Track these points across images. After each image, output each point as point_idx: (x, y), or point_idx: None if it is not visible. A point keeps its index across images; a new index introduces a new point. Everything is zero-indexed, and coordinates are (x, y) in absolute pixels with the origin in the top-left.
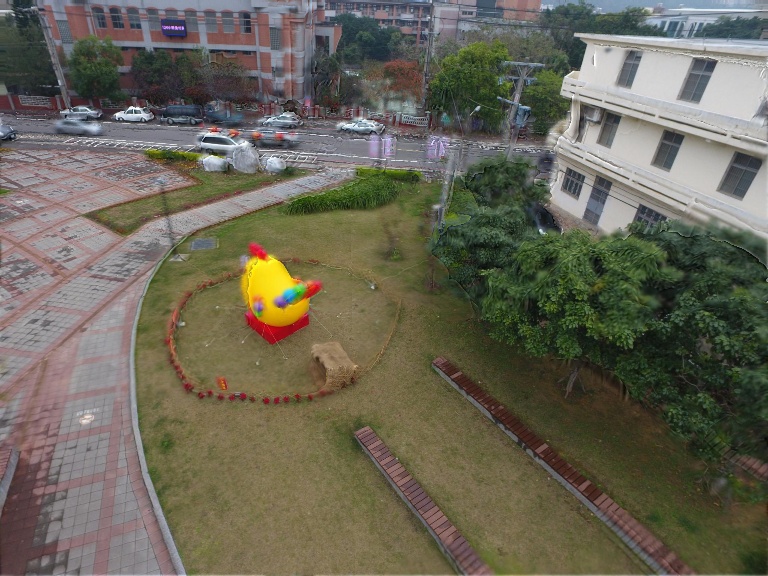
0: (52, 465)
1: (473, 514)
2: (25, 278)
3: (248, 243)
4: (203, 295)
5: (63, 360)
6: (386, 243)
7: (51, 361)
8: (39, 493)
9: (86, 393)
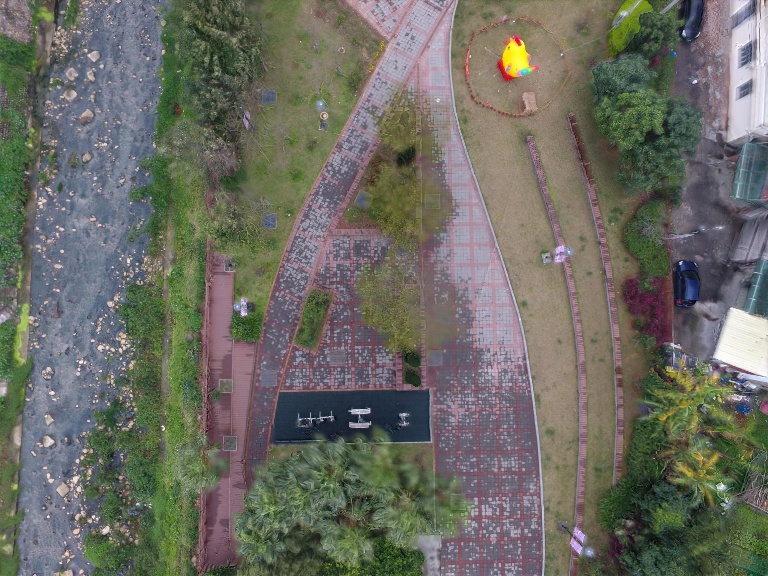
0: (431, 117)
1: (553, 176)
2: None
3: None
4: (479, 36)
5: (424, 65)
6: (584, 13)
7: (420, 64)
8: (430, 126)
9: (436, 87)
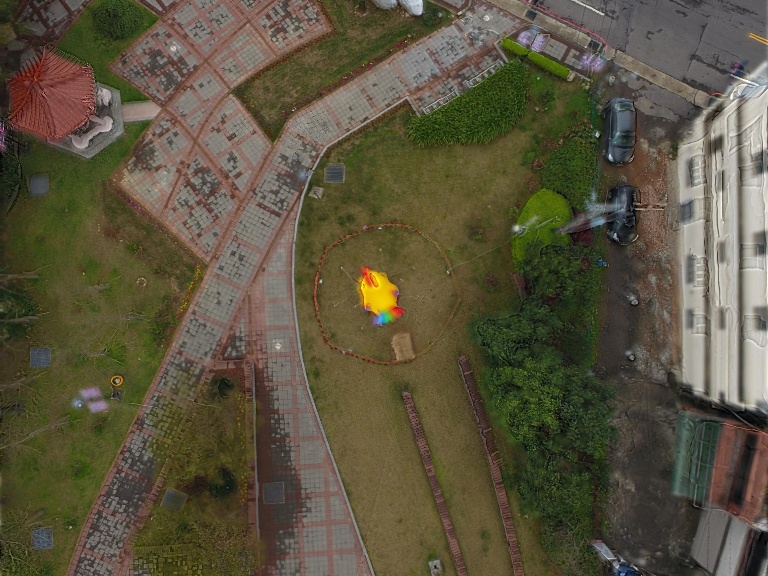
0: (269, 371)
1: (440, 450)
2: (215, 197)
3: (367, 185)
4: (333, 252)
5: (258, 296)
6: (478, 212)
7: (252, 296)
8: (267, 385)
9: (274, 326)
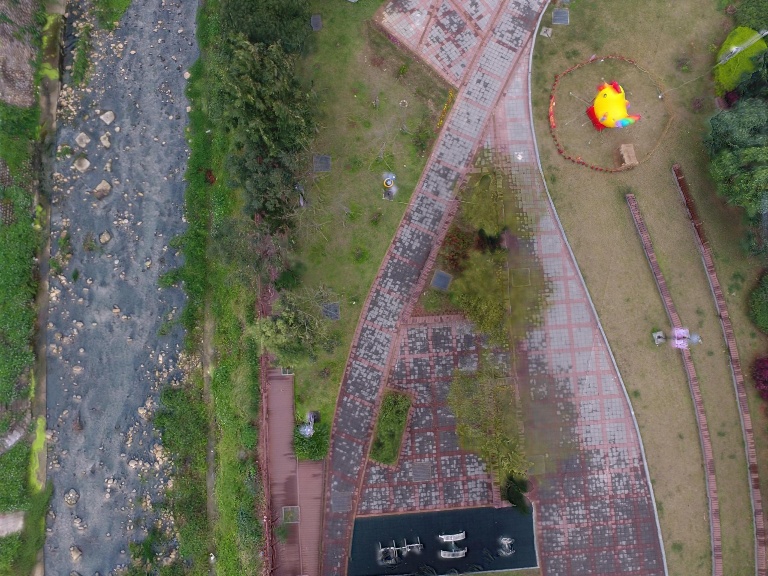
0: (513, 177)
1: (660, 241)
2: (461, 36)
3: (590, 26)
4: (563, 80)
5: (501, 117)
6: (683, 48)
7: (496, 116)
8: (512, 189)
9: (516, 142)
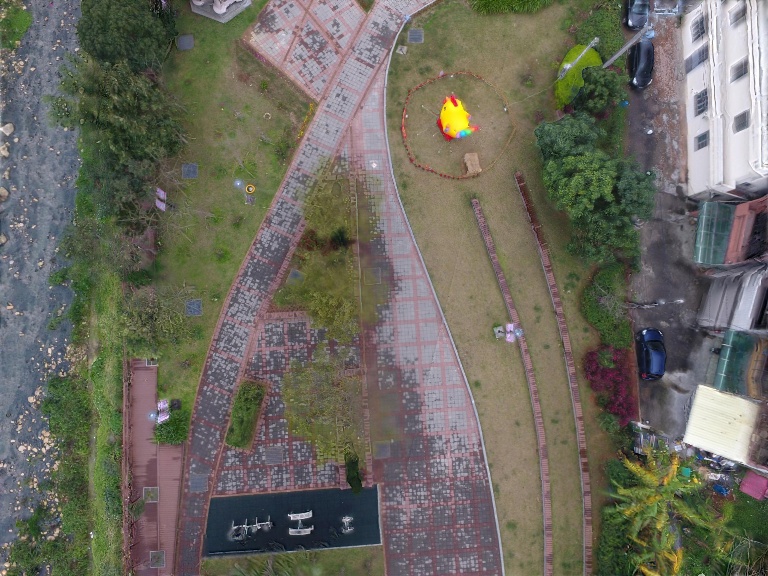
0: (367, 184)
1: (502, 242)
2: (323, 53)
3: (442, 44)
4: (415, 94)
5: (358, 128)
6: (527, 64)
7: (353, 127)
8: (366, 194)
9: (371, 150)
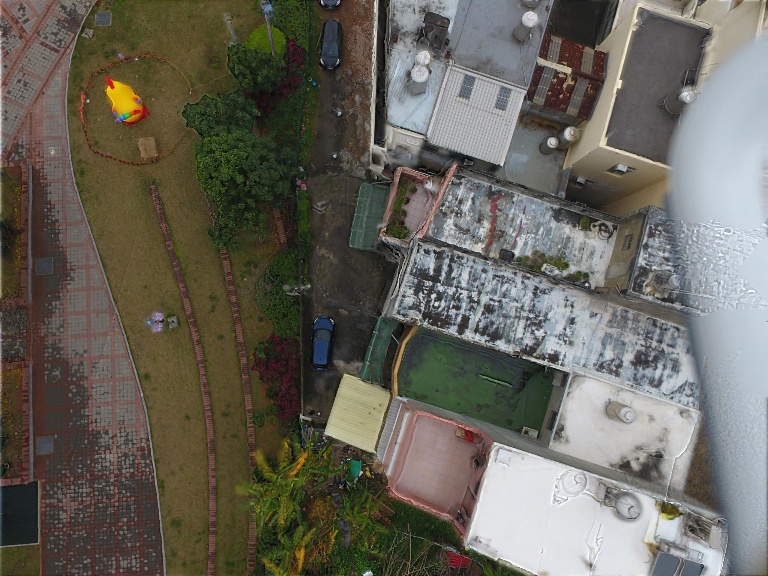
0: (44, 171)
1: (179, 229)
2: (6, 38)
3: (128, 26)
4: (98, 78)
5: (38, 114)
6: (215, 45)
7: (33, 113)
8: (42, 182)
9: (50, 137)
